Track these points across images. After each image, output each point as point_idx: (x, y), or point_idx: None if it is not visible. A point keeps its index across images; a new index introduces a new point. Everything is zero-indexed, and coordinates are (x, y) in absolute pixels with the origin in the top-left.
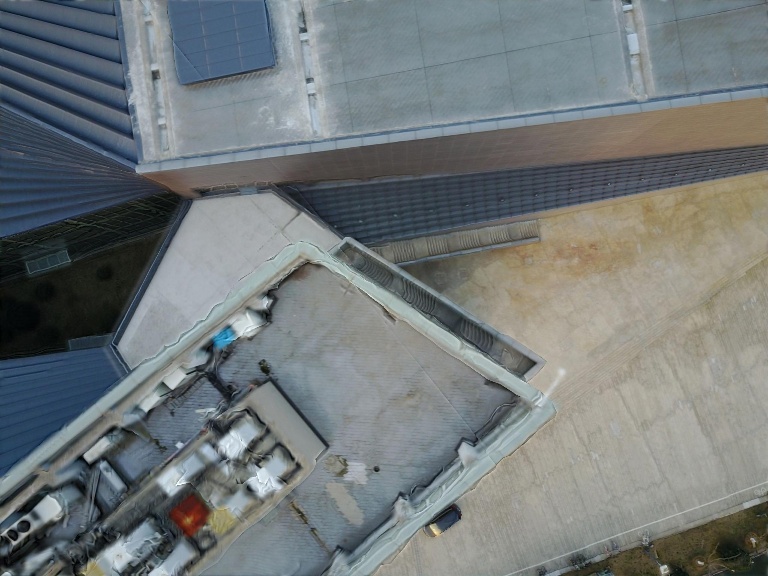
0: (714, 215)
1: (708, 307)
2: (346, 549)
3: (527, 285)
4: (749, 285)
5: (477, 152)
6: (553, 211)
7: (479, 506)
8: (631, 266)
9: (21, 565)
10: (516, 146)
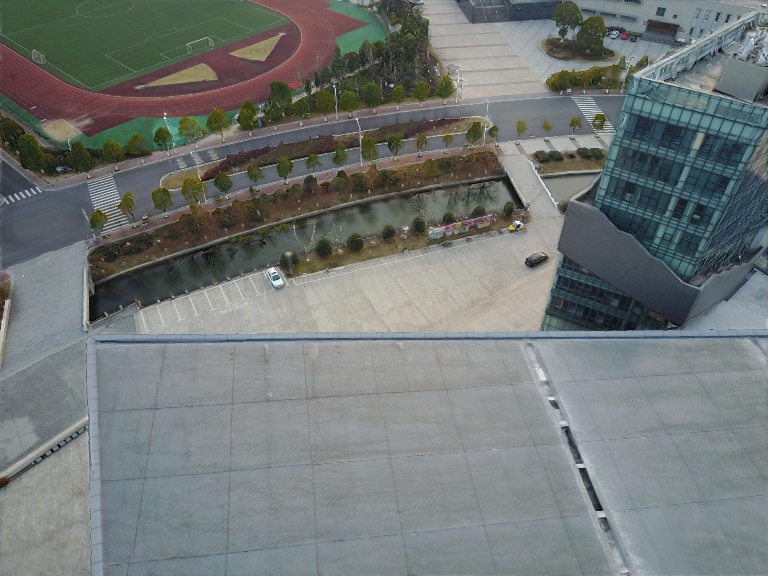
0: None
1: None
2: (688, 71)
3: None
4: None
5: None
6: None
7: (514, 267)
8: None
9: None
10: None
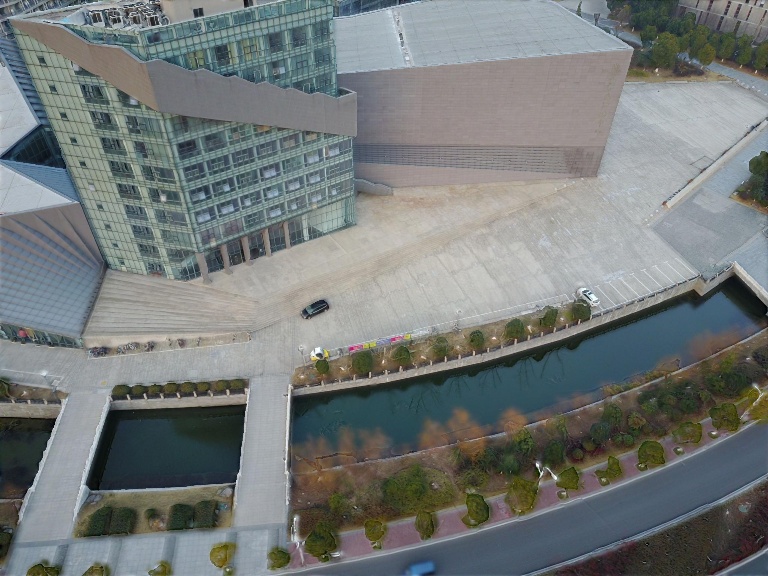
0: (488, 192)
1: (489, 226)
2: None
3: (384, 209)
4: (511, 219)
5: None
6: (396, 168)
7: (342, 306)
8: (443, 206)
9: (153, 5)
10: (367, 104)
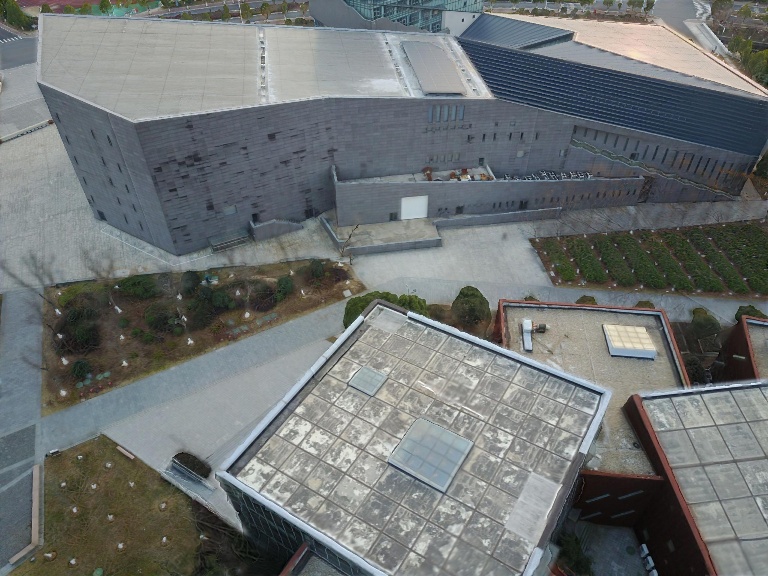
0: None
1: None
2: None
3: None
4: None
5: None
6: None
7: None
8: None
9: None
10: None
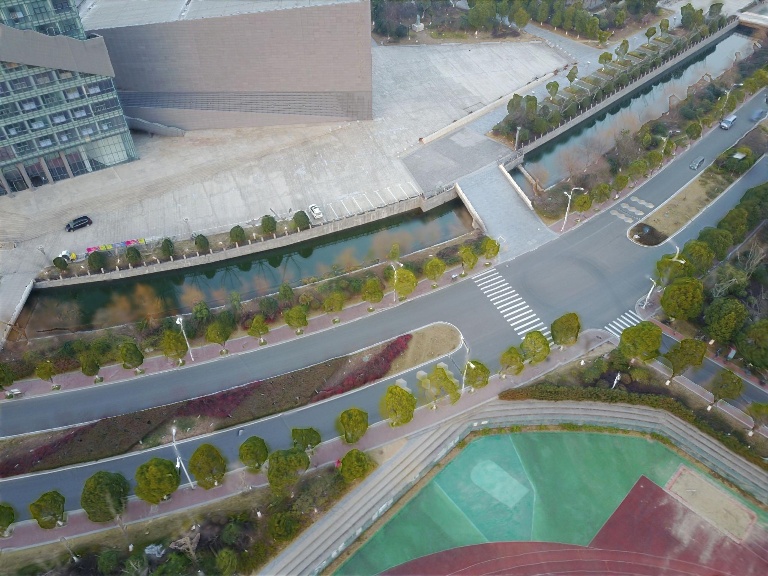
0: (269, 133)
1: (259, 160)
2: None
3: (170, 147)
4: (281, 154)
5: (136, 58)
6: (184, 112)
7: (104, 222)
8: None
9: None
10: (150, 55)
